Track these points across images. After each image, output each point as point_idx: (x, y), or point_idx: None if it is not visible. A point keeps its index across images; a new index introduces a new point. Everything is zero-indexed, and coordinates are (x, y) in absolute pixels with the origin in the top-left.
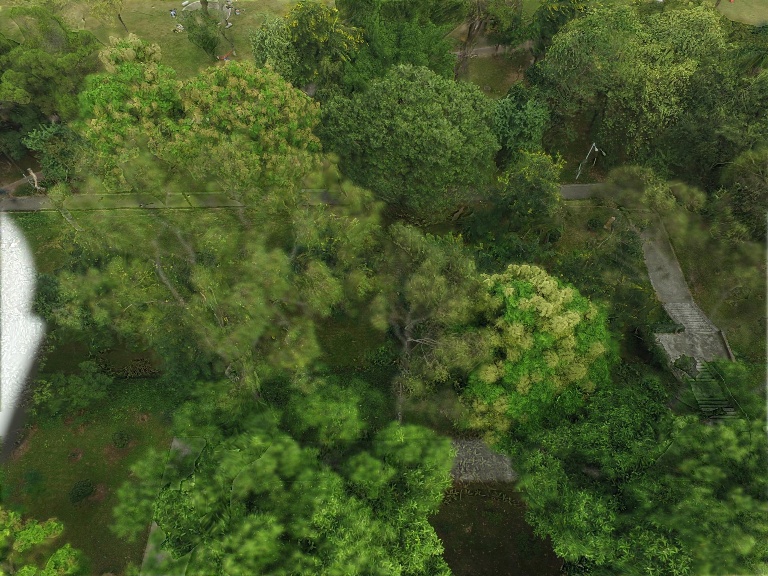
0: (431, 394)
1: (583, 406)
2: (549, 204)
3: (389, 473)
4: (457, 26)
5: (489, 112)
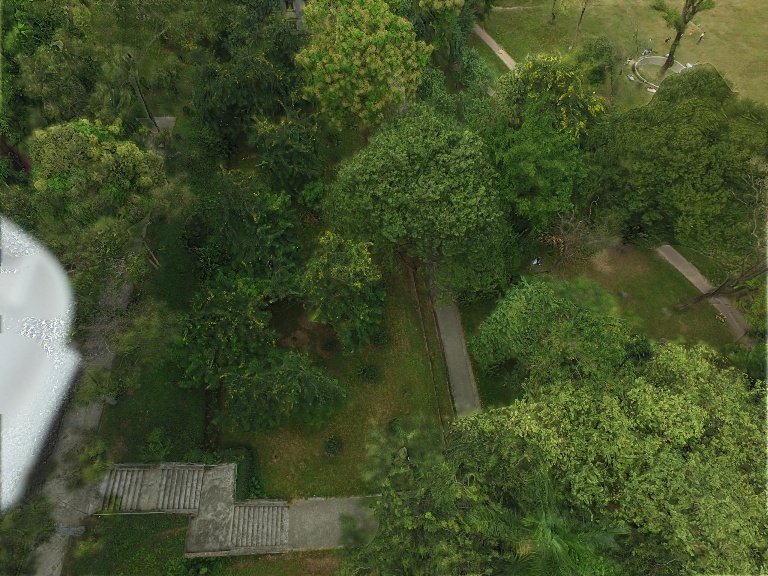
0: (184, 244)
1: (25, 197)
2: None
3: None
4: (693, 246)
5: (443, 226)
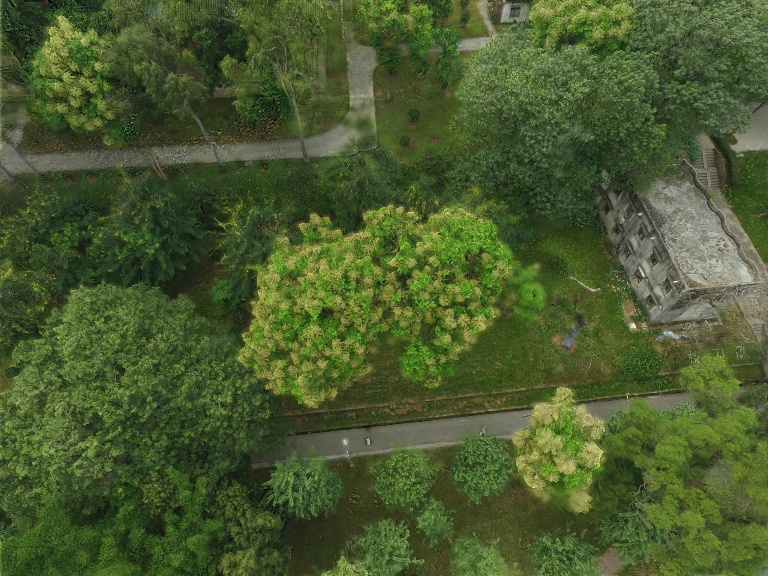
0: None
1: None
2: (4, 268)
3: (233, 147)
4: None
5: None
